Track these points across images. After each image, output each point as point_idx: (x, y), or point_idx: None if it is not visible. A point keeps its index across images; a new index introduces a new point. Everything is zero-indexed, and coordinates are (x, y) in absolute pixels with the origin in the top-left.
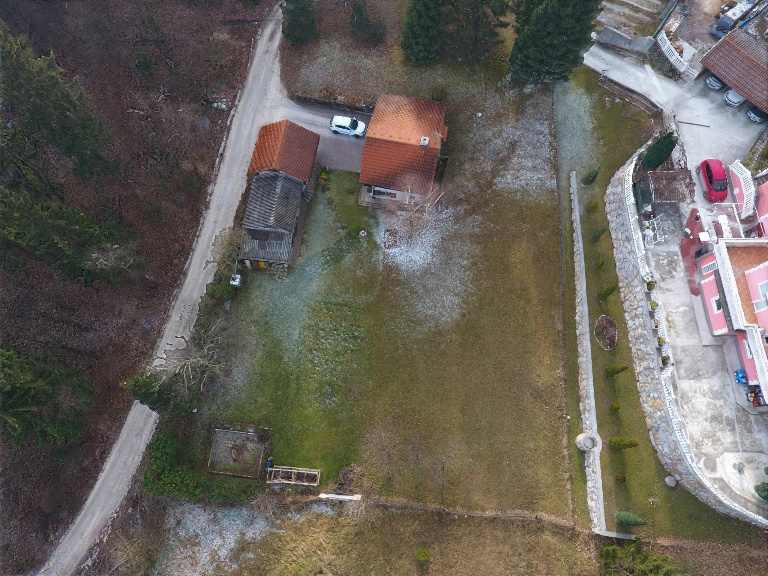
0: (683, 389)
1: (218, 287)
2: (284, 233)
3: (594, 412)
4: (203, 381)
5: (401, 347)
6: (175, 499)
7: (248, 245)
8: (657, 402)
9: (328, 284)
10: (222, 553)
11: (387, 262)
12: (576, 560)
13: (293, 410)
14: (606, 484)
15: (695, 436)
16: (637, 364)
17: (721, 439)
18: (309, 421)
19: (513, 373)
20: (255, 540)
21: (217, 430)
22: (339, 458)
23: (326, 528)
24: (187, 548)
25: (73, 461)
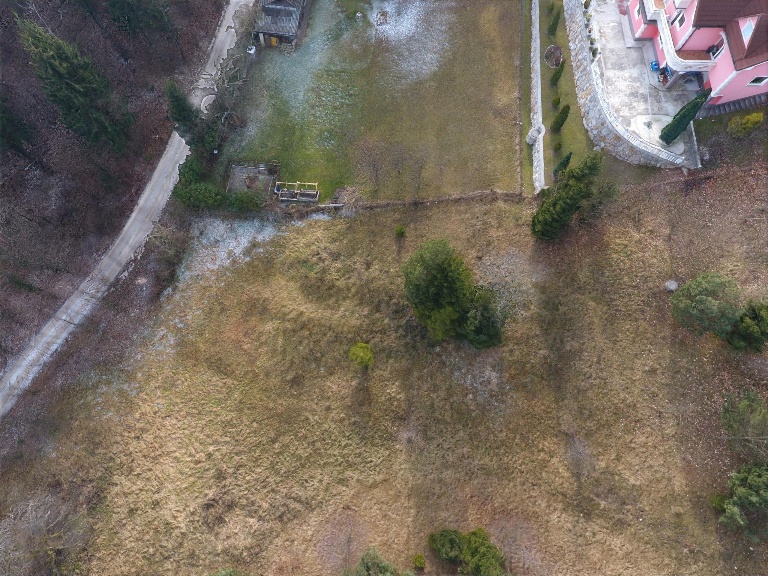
0: (609, 76)
1: (237, 49)
2: (293, 11)
3: (540, 110)
4: (224, 116)
5: (388, 97)
6: (199, 216)
7: (262, 20)
8: (588, 89)
9: (329, 56)
10: (237, 251)
11: (379, 36)
12: (521, 215)
13: (297, 151)
14: (547, 156)
15: (615, 105)
16: (576, 74)
17: (636, 107)
18: (311, 158)
19: (479, 101)
20: (264, 241)
21: (234, 166)
22: (335, 183)
23: (323, 228)
24: (208, 249)
25: (113, 200)
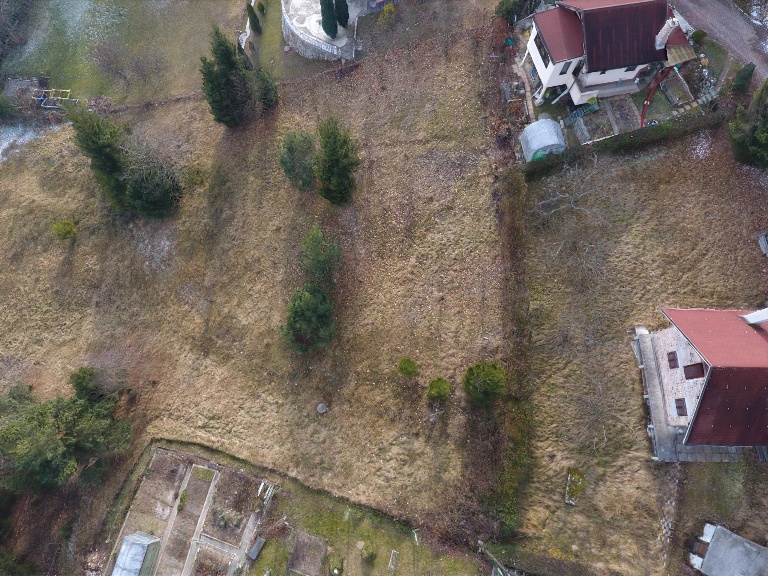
0: None
1: None
2: None
3: None
4: None
5: (150, 16)
6: None
7: None
8: None
9: None
10: None
11: None
12: None
13: (68, 65)
14: None
15: (296, 5)
16: None
17: (314, 7)
18: (78, 72)
19: (216, 15)
20: (23, 143)
21: (10, 79)
22: (95, 93)
23: (73, 131)
24: None
25: None
